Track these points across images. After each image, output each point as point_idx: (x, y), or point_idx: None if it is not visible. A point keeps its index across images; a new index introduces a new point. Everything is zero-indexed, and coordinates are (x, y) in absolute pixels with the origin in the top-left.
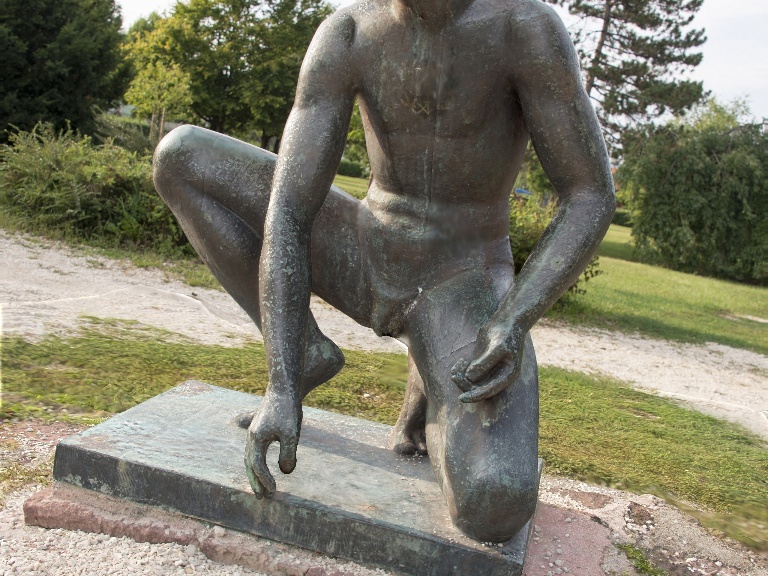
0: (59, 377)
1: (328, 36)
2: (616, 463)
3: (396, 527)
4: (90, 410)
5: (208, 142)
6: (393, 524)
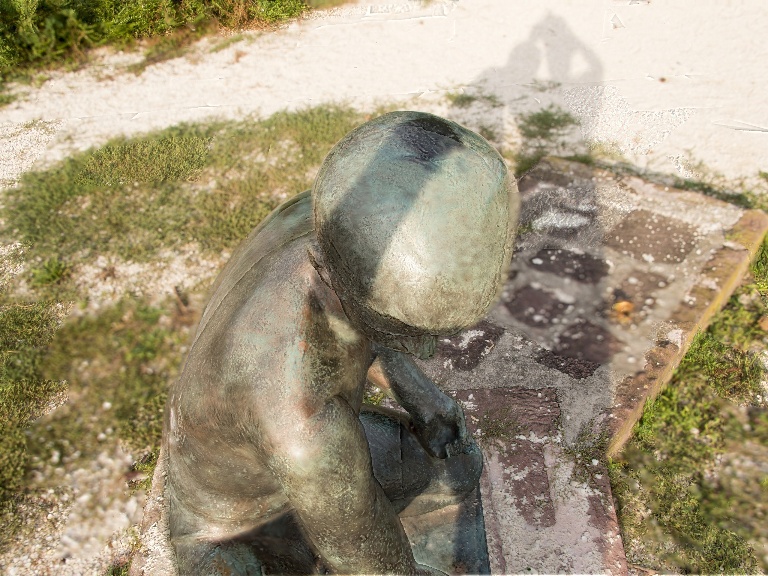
0: None
1: None
2: None
3: (483, 540)
4: None
5: None
6: (480, 543)
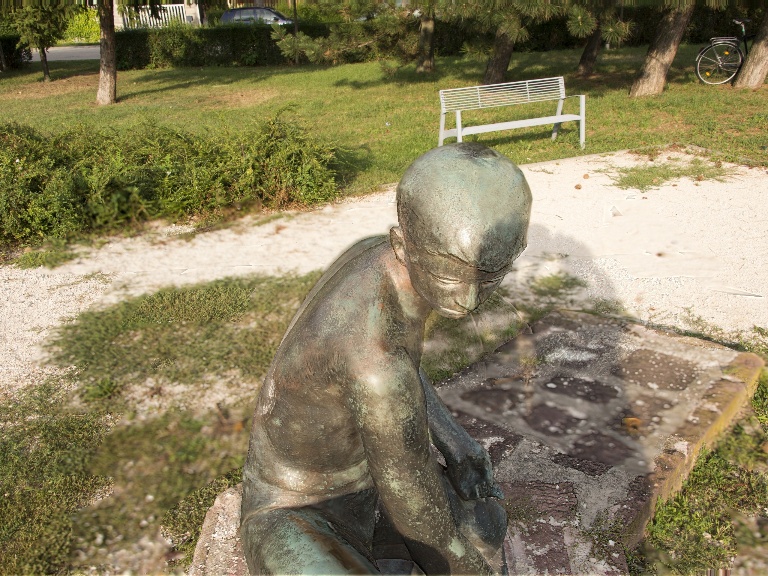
0: None
1: (417, 379)
2: (5, 543)
3: None
4: None
5: None
6: None
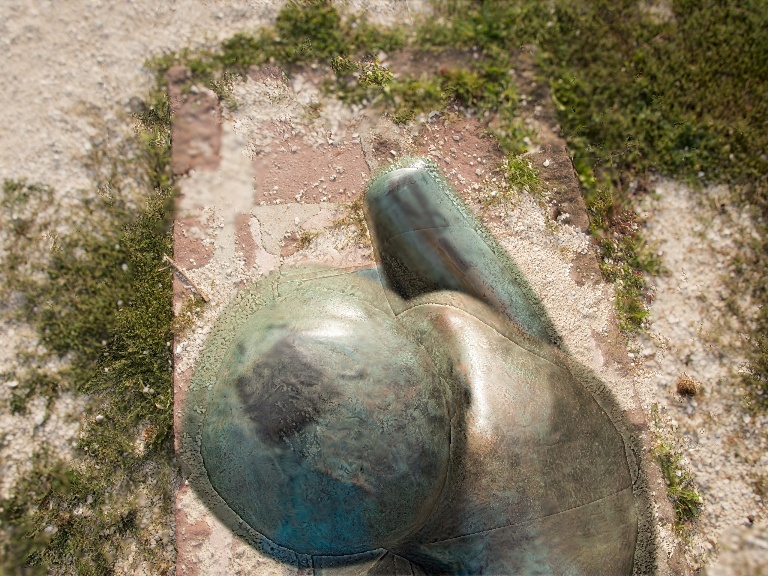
0: (626, 28)
1: None
2: None
3: None
4: (555, 122)
5: (386, 233)
6: None
